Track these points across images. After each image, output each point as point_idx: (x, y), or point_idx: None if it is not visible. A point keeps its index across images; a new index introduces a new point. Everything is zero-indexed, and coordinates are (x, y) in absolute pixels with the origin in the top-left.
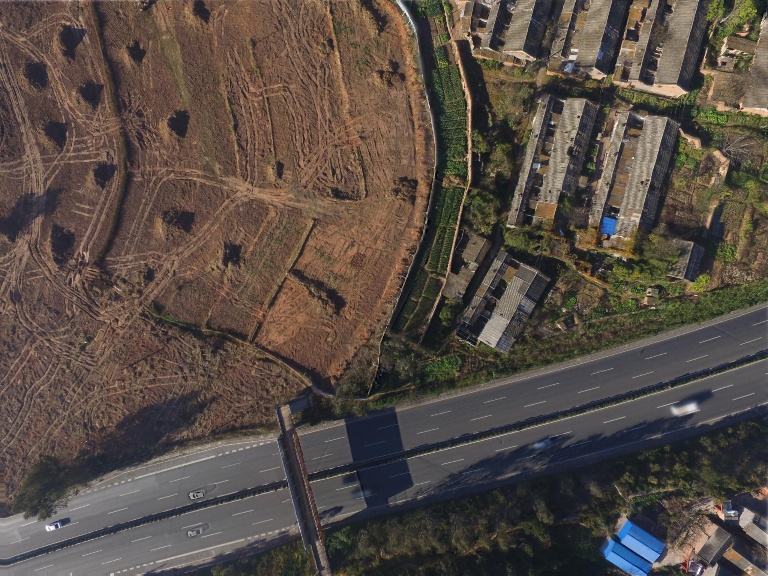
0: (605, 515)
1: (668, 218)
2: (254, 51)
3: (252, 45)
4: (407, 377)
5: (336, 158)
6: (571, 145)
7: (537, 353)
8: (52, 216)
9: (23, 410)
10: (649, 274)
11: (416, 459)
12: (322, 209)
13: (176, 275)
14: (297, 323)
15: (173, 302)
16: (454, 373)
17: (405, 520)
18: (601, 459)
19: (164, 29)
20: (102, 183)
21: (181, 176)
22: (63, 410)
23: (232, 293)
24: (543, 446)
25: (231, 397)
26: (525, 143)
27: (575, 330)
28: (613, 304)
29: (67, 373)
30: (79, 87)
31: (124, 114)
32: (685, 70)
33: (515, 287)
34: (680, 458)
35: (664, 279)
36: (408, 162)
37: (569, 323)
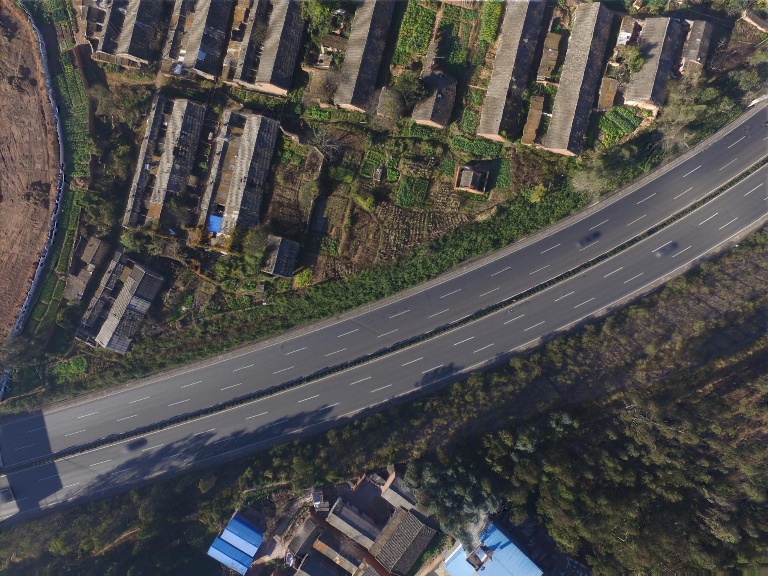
0: (219, 511)
1: (273, 215)
2: None
3: None
4: (38, 380)
5: None
6: (175, 145)
7: (164, 352)
8: None
9: None
10: (240, 270)
11: (63, 461)
12: None
13: None
14: None
15: None
16: (84, 374)
17: (41, 523)
18: (242, 455)
19: None
20: None
21: None
22: None
23: None
24: (187, 444)
25: None
26: None
27: (192, 328)
28: (228, 301)
29: None
30: None
31: None
32: (280, 69)
33: (128, 287)
34: (302, 451)
35: (264, 275)
36: (42, 166)
37: (187, 321)
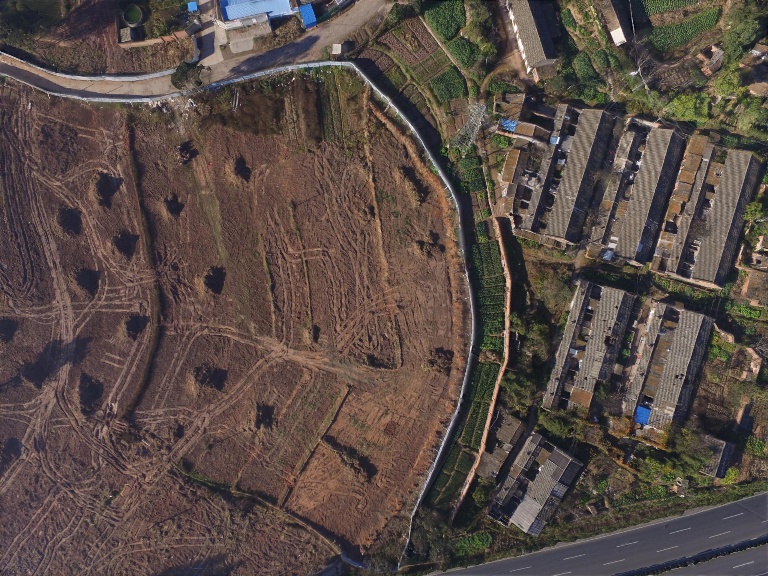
0: None
1: (700, 410)
2: (294, 213)
3: (293, 207)
4: None
5: (373, 325)
6: (608, 335)
7: (566, 531)
8: (81, 364)
9: (43, 562)
10: (682, 472)
11: None
12: (357, 376)
13: (206, 433)
14: (328, 489)
15: (203, 461)
16: (484, 548)
17: None
18: None
19: (203, 184)
20: (134, 335)
21: (215, 332)
22: (85, 565)
23: (263, 455)
24: None
25: (259, 561)
26: (562, 325)
27: (605, 514)
28: (643, 490)
29: (91, 527)
30: (114, 238)
31: (159, 267)
32: (722, 268)
33: (548, 471)
34: None
35: None
36: (445, 333)
37: (599, 506)
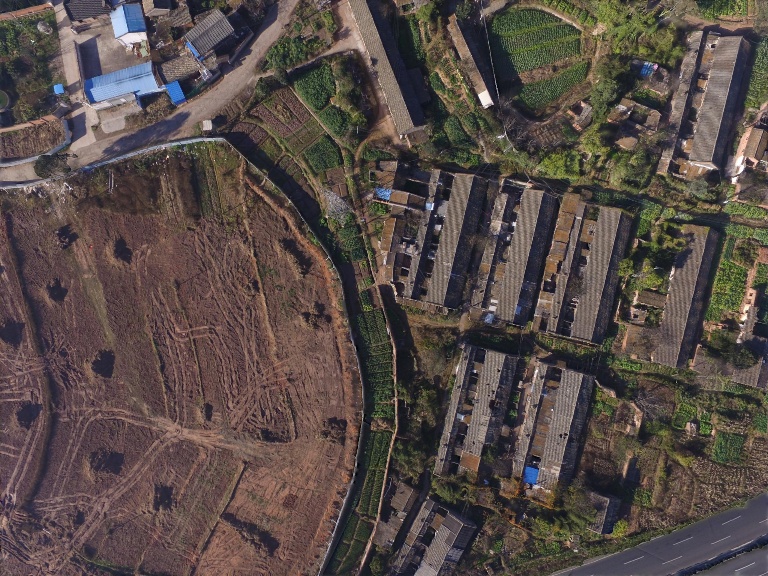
0: None
1: (587, 465)
2: (178, 293)
3: (176, 287)
4: None
5: (265, 399)
6: (492, 399)
7: None
8: None
9: None
10: (568, 531)
11: None
12: (252, 451)
13: (107, 517)
14: (231, 566)
15: (104, 546)
16: None
17: None
18: None
19: (86, 267)
20: (27, 424)
21: (109, 416)
22: None
23: (164, 537)
24: None
25: None
26: (450, 389)
27: (502, 573)
28: (538, 547)
29: None
30: None
31: (47, 354)
32: (599, 326)
33: (442, 537)
34: None
35: None
36: (337, 403)
37: (496, 565)
